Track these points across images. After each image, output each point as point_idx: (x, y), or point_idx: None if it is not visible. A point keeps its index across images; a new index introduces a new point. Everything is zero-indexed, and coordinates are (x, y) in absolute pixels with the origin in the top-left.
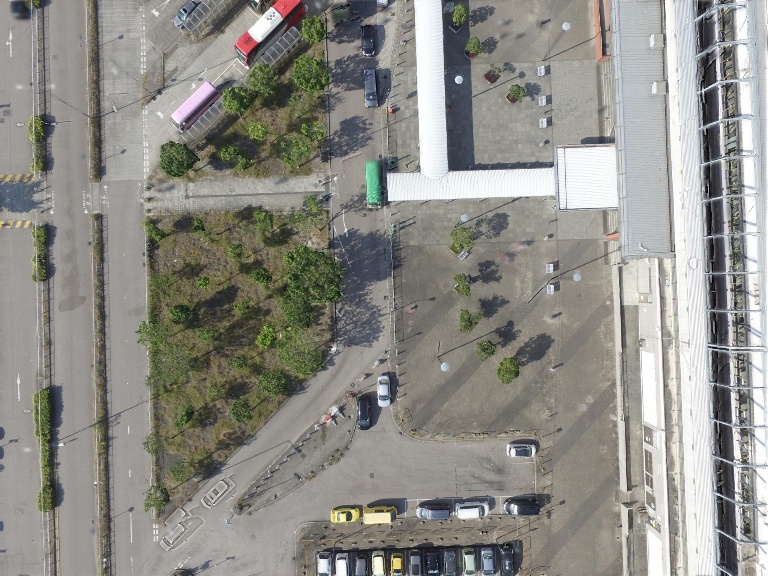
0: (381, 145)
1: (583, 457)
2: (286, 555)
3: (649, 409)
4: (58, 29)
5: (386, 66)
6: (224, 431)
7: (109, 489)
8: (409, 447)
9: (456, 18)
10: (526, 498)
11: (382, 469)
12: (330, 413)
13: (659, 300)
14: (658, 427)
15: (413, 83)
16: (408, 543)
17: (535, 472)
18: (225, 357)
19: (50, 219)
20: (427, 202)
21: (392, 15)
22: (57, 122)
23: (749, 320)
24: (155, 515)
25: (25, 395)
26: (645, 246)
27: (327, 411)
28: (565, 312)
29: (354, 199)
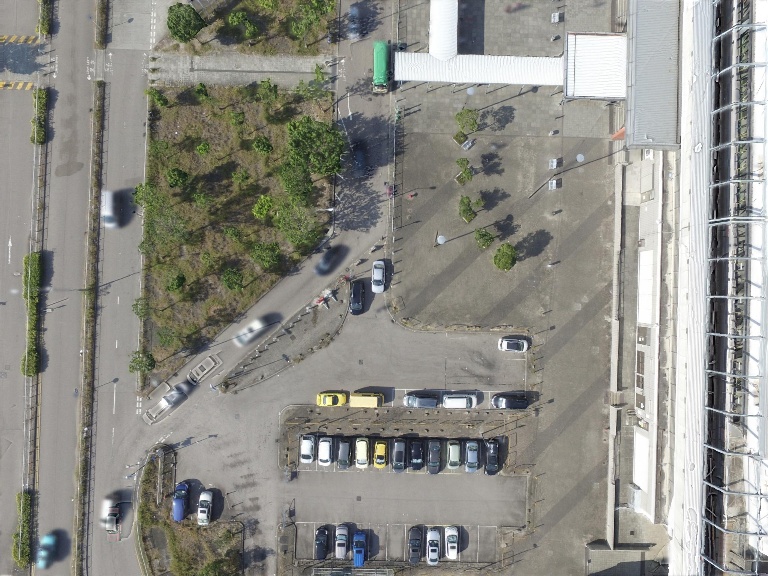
0: (391, 30)
1: (575, 356)
2: (269, 437)
3: (644, 308)
4: None
5: None
6: (214, 307)
7: (95, 358)
8: (400, 336)
9: None
10: (515, 394)
11: (372, 356)
12: (323, 296)
13: (661, 193)
14: (652, 323)
15: None
16: (393, 432)
17: (525, 369)
18: (220, 233)
19: (52, 83)
20: (434, 90)
21: None
22: None
23: (751, 202)
24: (139, 387)
25: (16, 258)
26: (650, 137)
27: (320, 294)
28: (566, 210)
29: (360, 83)
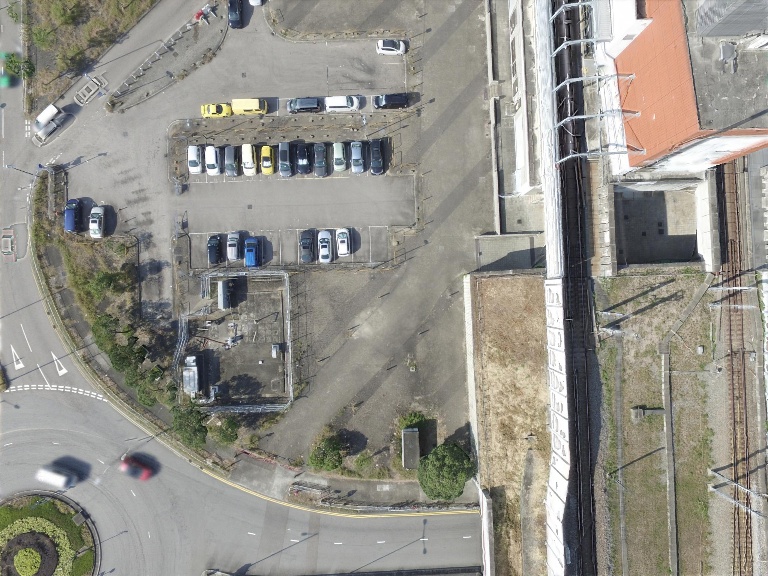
0: None
1: (452, 56)
2: (158, 152)
3: None
4: None
5: None
6: (97, 29)
7: None
8: (281, 47)
9: None
10: None
11: (254, 69)
12: None
13: None
14: None
15: None
16: (279, 140)
17: (405, 71)
18: None
19: None
20: None
21: None
22: None
23: None
24: (27, 109)
25: None
26: None
27: None
28: None
29: None
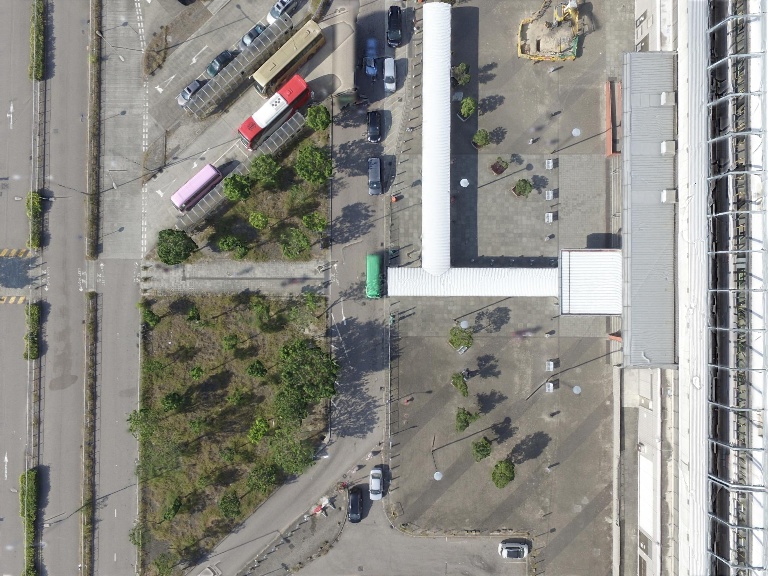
0: (383, 233)
1: (576, 559)
2: None
3: (645, 516)
4: (60, 102)
5: (391, 152)
6: (212, 518)
7: (93, 572)
8: (399, 541)
9: (464, 111)
10: None
11: (371, 563)
12: (320, 504)
13: (660, 411)
14: (654, 538)
15: (418, 171)
16: None
17: (526, 572)
18: (216, 443)
19: (44, 296)
20: None
21: (400, 101)
22: (55, 197)
23: None
24: None
25: (12, 473)
26: (648, 355)
27: (318, 502)
28: (564, 411)
29: (353, 287)
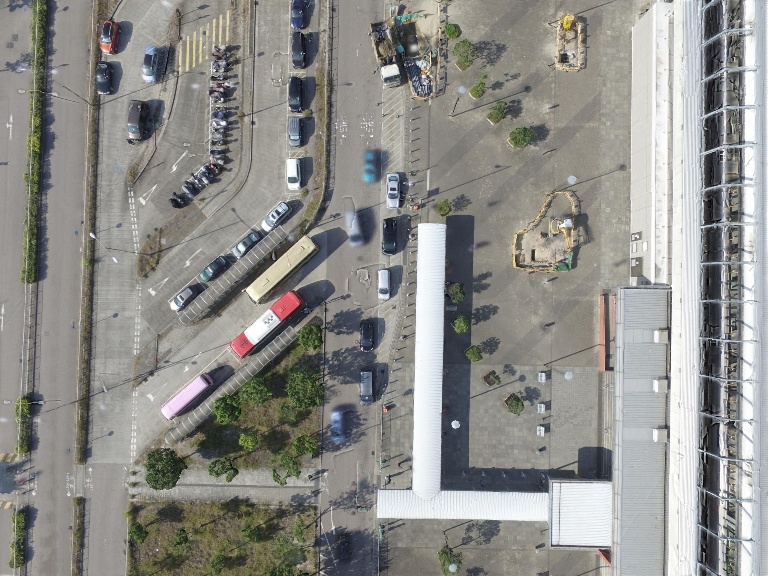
0: (374, 442)
1: None
2: None
3: None
4: (52, 304)
5: (384, 360)
6: None
7: None
8: None
9: (458, 331)
10: None
11: None
12: None
13: None
14: None
15: (411, 381)
16: None
17: None
18: None
19: (32, 501)
20: None
21: (393, 308)
22: (45, 401)
23: None
24: None
25: None
26: None
27: None
28: None
29: (343, 496)
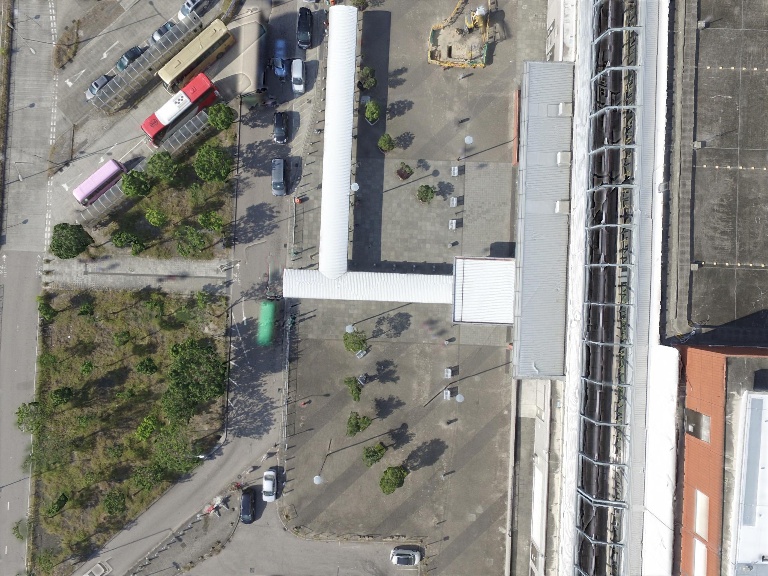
0: (287, 234)
1: (468, 568)
2: None
3: (536, 527)
4: None
5: (298, 154)
6: (105, 514)
7: None
8: (292, 544)
9: (367, 115)
10: None
11: (263, 564)
12: (214, 504)
13: (549, 422)
14: (540, 550)
15: None
16: None
17: None
18: (111, 439)
19: None
20: None
21: (308, 102)
22: None
23: None
24: None
25: None
26: (538, 366)
27: (211, 501)
28: (461, 419)
29: (255, 287)
